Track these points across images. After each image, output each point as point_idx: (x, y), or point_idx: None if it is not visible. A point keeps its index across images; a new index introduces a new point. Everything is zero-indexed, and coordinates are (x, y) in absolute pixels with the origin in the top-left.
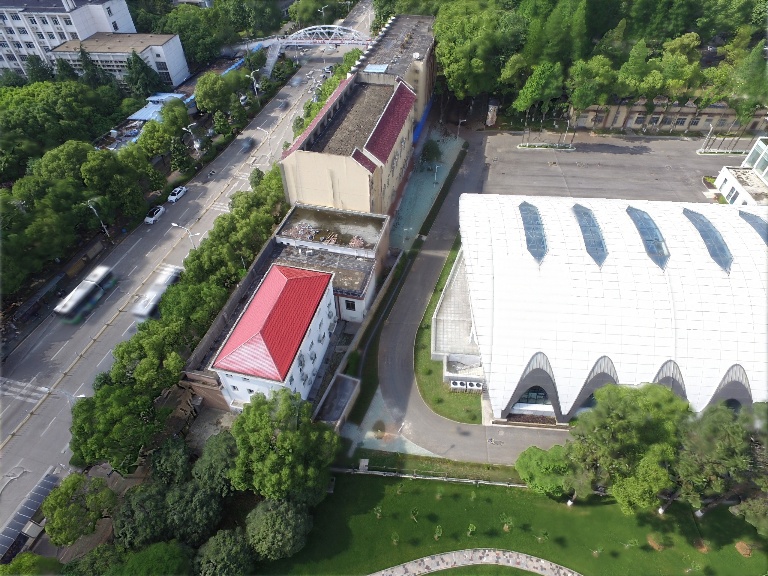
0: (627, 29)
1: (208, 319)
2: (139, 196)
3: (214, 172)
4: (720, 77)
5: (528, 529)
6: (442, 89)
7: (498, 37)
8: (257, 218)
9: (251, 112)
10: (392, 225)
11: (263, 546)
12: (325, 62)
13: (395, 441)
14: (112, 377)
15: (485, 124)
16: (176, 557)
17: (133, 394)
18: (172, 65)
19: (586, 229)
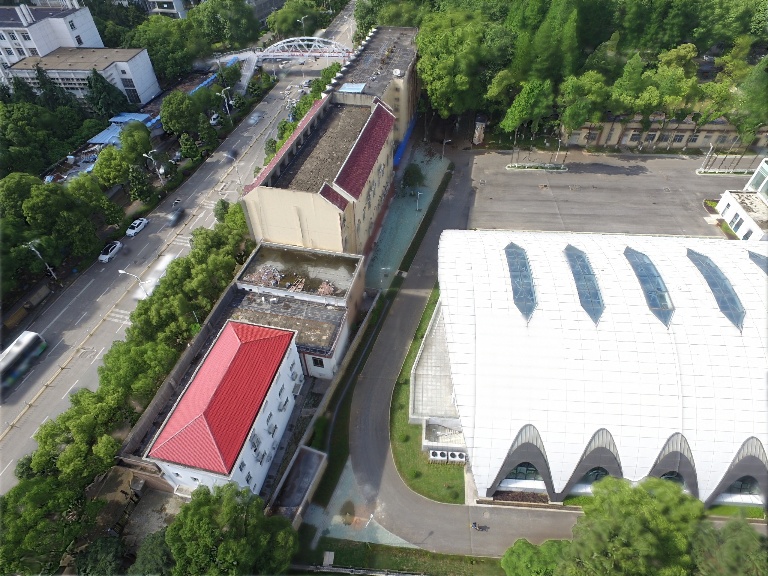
0: (620, 40)
1: (153, 387)
2: (90, 233)
3: (179, 200)
4: (720, 93)
5: None
6: (425, 106)
7: (484, 52)
8: (215, 262)
9: (223, 132)
10: (370, 260)
11: None
12: (304, 76)
13: None
14: (32, 467)
15: (472, 142)
16: None
17: (59, 484)
18: (139, 82)
19: (580, 277)
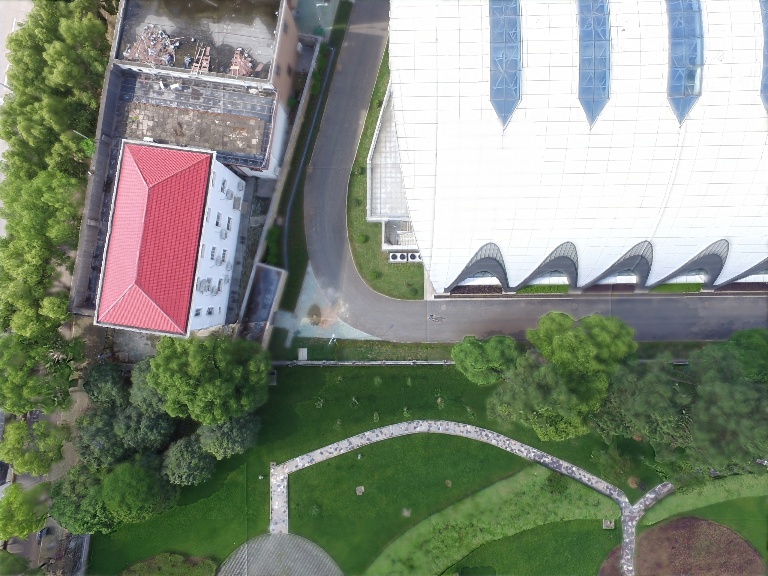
0: None
1: (71, 229)
2: None
3: None
4: None
5: (459, 401)
6: None
7: None
8: (72, 32)
9: None
10: None
11: (218, 457)
12: None
13: (332, 326)
14: None
15: None
16: (143, 479)
17: None
18: None
19: (588, 45)
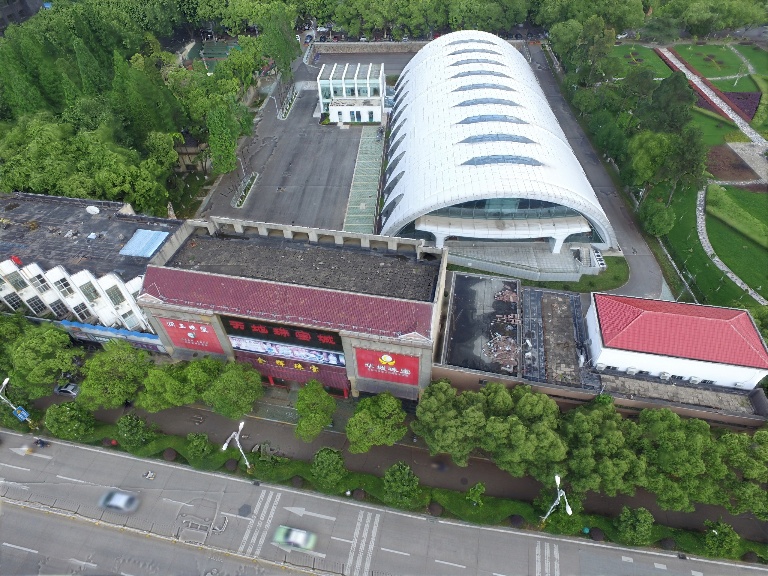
0: None
1: None
2: None
3: None
4: (241, 63)
5: (685, 242)
6: None
7: (111, 132)
8: None
9: None
10: None
11: None
12: None
13: None
14: None
15: None
16: None
17: None
18: None
19: None
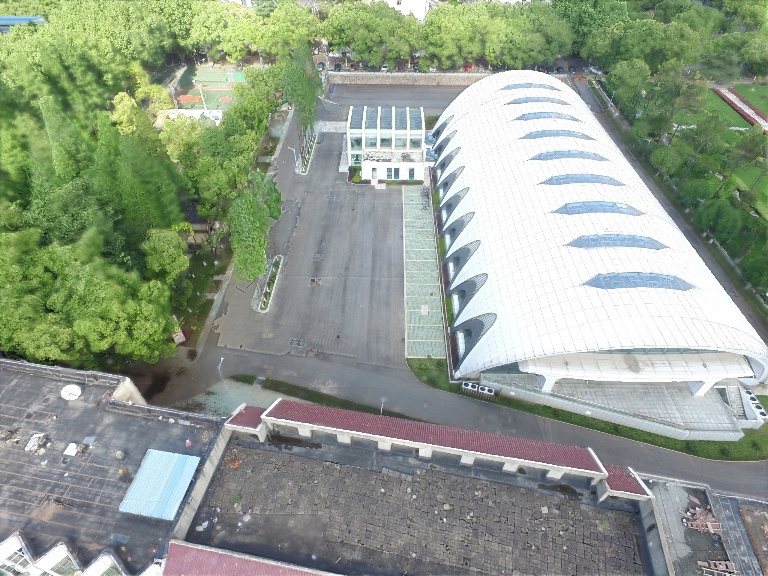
0: None
1: None
2: None
3: None
4: (255, 108)
5: None
6: None
7: (95, 239)
8: None
9: None
10: None
11: None
12: None
13: None
14: None
15: None
16: None
17: None
18: None
19: (622, 244)
